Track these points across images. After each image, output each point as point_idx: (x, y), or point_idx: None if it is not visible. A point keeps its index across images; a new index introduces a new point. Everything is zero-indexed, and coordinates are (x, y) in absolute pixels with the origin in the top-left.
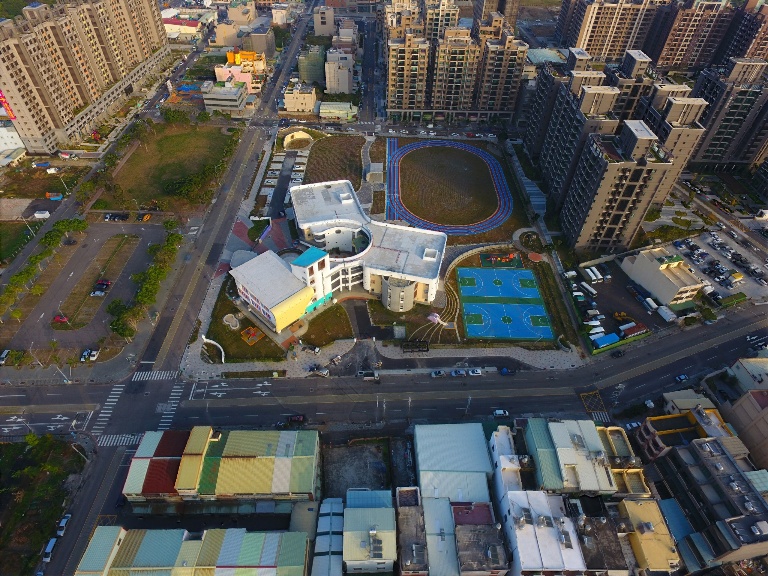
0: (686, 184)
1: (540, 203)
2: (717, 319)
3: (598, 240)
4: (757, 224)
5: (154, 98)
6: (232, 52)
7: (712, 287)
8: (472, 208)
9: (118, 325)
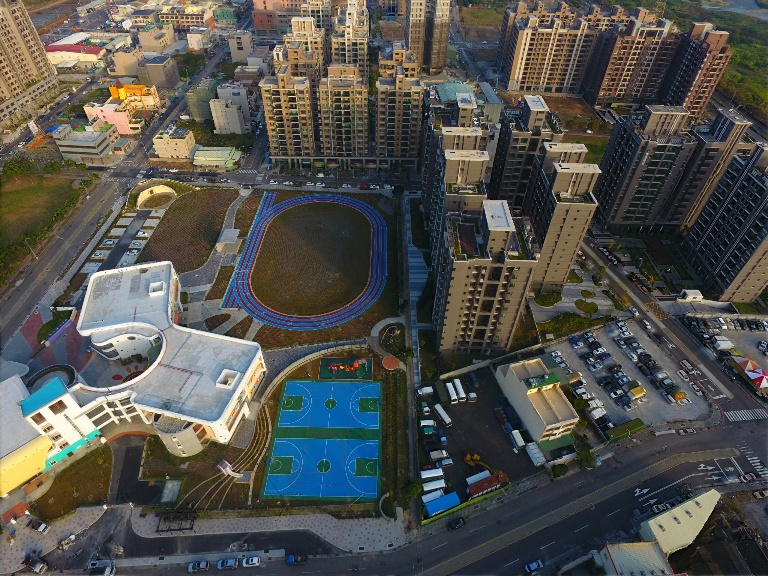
0: (603, 251)
1: (420, 281)
2: (602, 459)
3: (468, 342)
4: (678, 308)
5: (15, 141)
6: (115, 86)
7: (602, 410)
8: (334, 289)
9: None
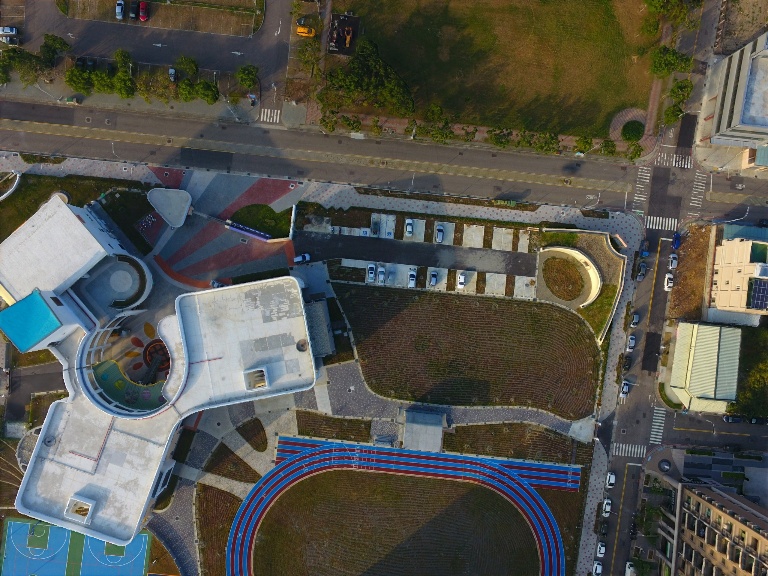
0: None
1: None
2: None
3: None
4: None
5: None
6: None
7: None
8: None
9: (2, 59)
